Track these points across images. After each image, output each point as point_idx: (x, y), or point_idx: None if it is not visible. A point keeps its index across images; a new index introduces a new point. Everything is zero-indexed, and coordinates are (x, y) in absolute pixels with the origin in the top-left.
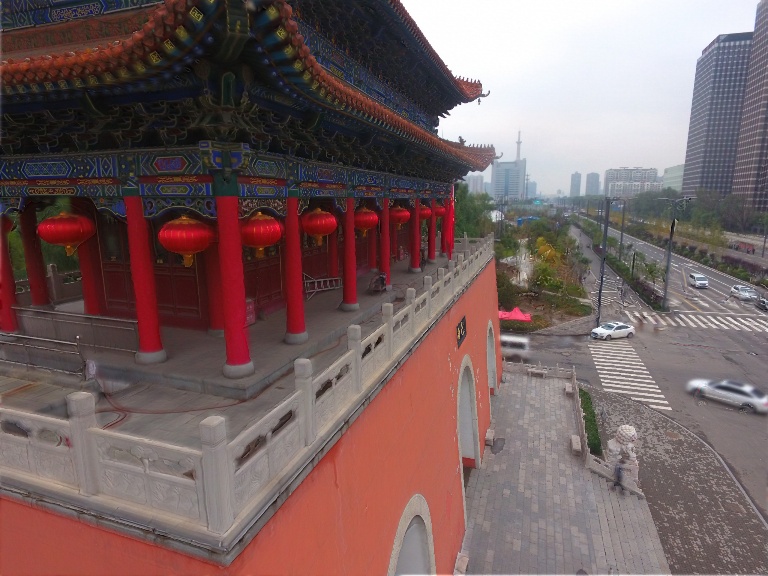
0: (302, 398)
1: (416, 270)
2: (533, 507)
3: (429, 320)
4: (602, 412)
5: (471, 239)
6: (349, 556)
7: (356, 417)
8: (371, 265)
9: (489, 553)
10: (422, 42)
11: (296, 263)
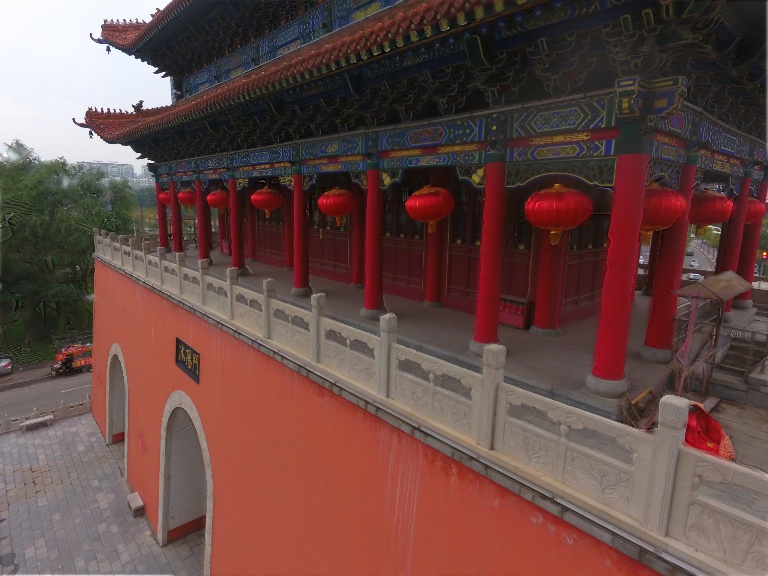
0: None
1: None
2: None
3: None
4: None
5: None
6: None
7: None
8: None
9: None
10: None
11: None
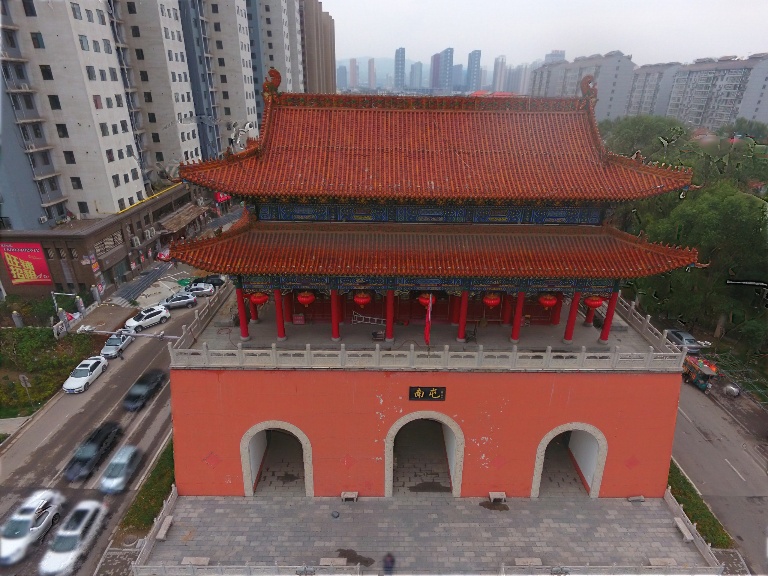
0: (203, 352)
1: (458, 339)
2: (424, 533)
3: (338, 365)
4: (561, 568)
5: (667, 341)
6: (224, 403)
7: (231, 369)
8: (452, 320)
9: (370, 511)
10: (420, 199)
11: (277, 312)
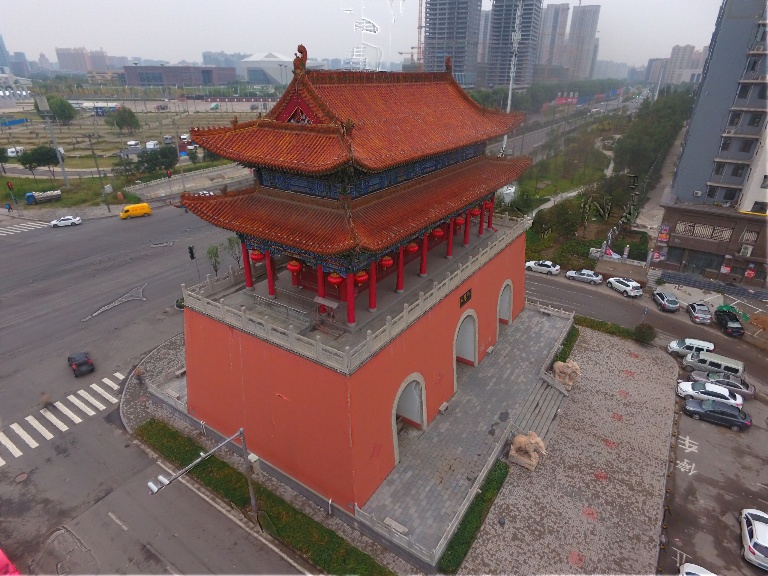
0: None
1: None
2: None
3: None
4: None
5: (200, 296)
6: None
7: None
8: None
9: None
10: None
11: None
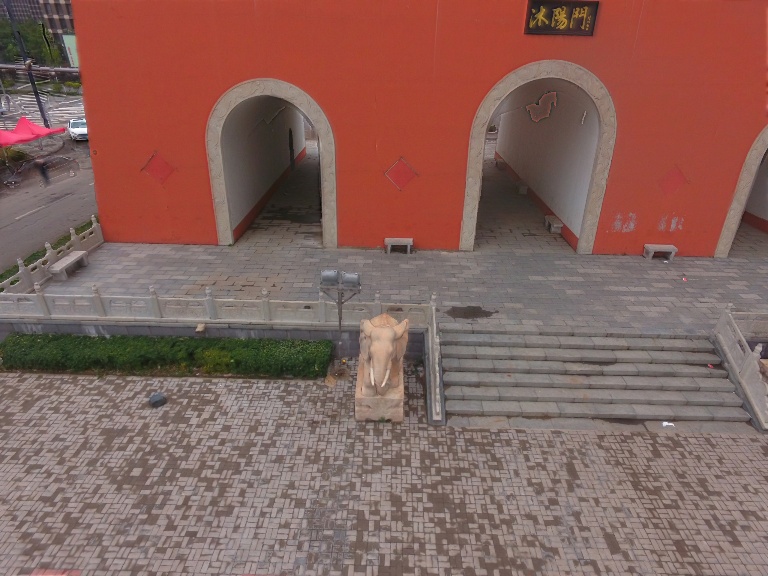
0: None
1: None
2: None
3: None
4: None
5: None
6: None
7: None
8: None
9: None
10: None
11: None
